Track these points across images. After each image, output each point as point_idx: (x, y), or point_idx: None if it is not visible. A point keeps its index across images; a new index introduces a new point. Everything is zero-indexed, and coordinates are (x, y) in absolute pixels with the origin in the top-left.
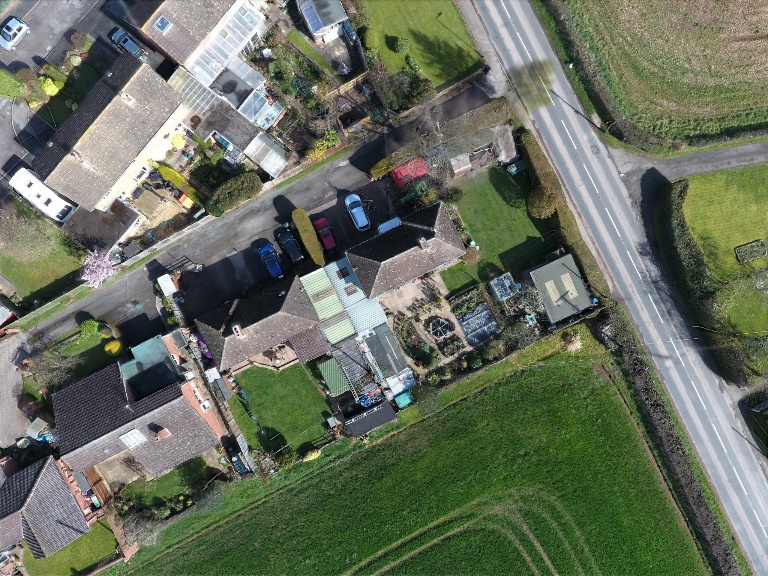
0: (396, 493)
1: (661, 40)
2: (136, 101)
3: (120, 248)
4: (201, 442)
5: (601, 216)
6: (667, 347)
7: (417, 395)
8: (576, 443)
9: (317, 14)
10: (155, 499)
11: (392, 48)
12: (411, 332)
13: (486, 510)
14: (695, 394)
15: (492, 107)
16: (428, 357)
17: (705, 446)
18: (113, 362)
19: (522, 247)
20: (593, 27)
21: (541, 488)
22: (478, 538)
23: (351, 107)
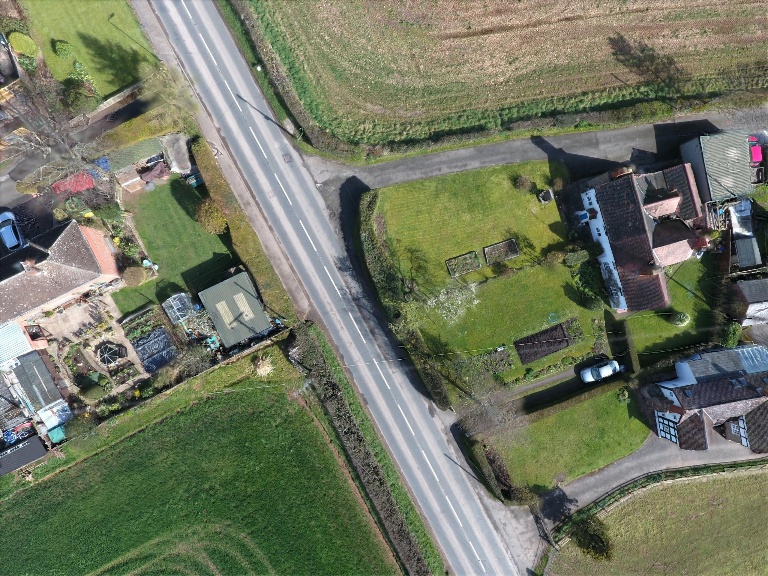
0: (63, 534)
1: (363, 39)
2: None
3: None
4: None
5: (295, 229)
6: (370, 369)
7: (65, 430)
8: (267, 475)
9: None
10: None
11: None
12: (79, 359)
13: (167, 550)
14: (402, 419)
15: (152, 115)
16: (89, 387)
17: (414, 475)
18: None
19: (208, 265)
20: (287, 26)
21: (229, 525)
22: None
23: (13, 117)
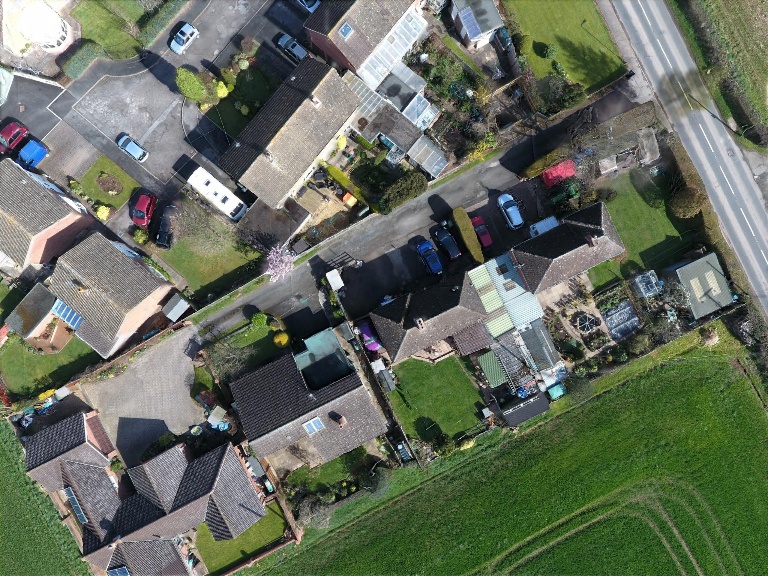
0: (544, 481)
1: None
2: (322, 104)
3: (289, 244)
4: (371, 430)
5: (736, 216)
6: None
7: (572, 387)
8: (713, 434)
9: (475, 21)
10: (319, 485)
11: (539, 54)
12: (558, 327)
13: (628, 498)
14: None
15: (641, 111)
16: (578, 351)
17: None
18: (279, 353)
19: (661, 246)
20: (728, 34)
21: (680, 477)
22: (621, 525)
23: (500, 110)
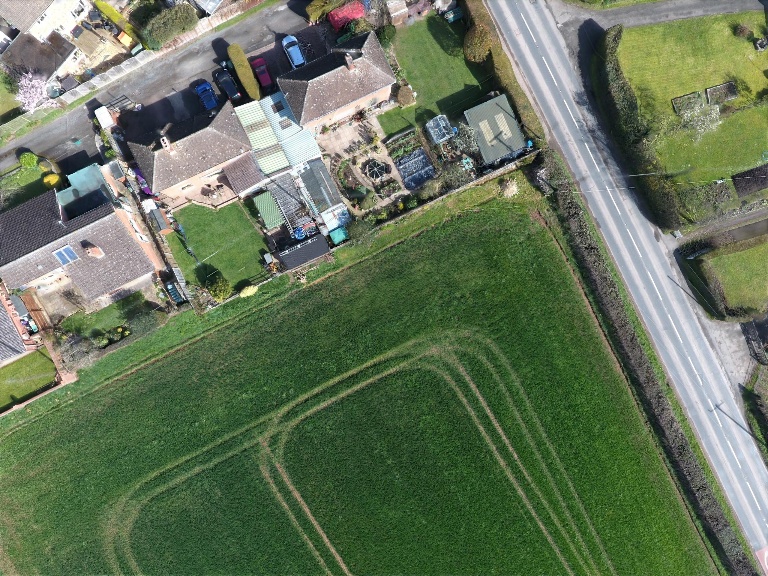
0: (333, 331)
1: None
2: None
3: (58, 82)
4: (136, 267)
5: (538, 65)
6: (603, 195)
7: (350, 227)
8: (512, 287)
9: None
10: (94, 331)
11: None
12: (348, 174)
13: (422, 351)
14: (631, 242)
15: None
16: (363, 195)
17: (641, 294)
18: None
19: (460, 95)
20: None
21: (477, 331)
22: (414, 378)
23: None
